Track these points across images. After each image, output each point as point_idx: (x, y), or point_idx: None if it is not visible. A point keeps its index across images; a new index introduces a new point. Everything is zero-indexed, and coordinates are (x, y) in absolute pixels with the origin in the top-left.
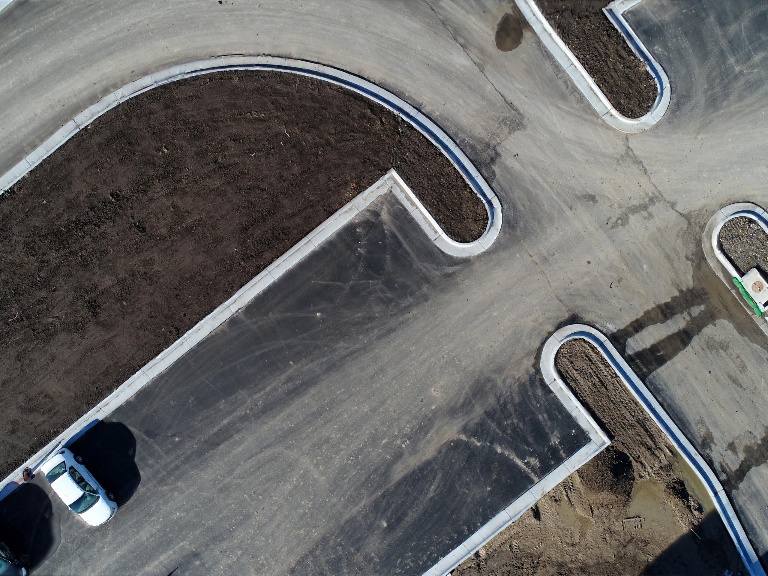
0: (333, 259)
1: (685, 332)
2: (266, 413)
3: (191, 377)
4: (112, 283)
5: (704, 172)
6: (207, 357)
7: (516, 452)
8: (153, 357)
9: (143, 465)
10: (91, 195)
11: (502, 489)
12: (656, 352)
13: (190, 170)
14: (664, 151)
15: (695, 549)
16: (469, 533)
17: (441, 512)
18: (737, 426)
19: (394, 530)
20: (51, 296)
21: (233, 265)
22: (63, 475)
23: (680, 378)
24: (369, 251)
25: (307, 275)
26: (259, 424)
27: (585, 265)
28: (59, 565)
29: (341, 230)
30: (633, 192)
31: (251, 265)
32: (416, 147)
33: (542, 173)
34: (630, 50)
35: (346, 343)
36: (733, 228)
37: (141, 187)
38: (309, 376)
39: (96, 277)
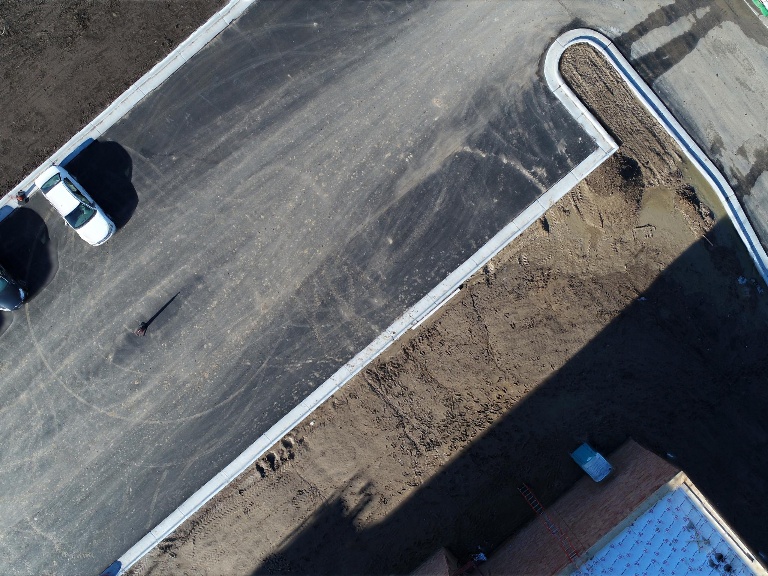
0: None
1: (691, 34)
2: (265, 129)
3: (186, 92)
4: None
5: None
6: (202, 71)
7: (522, 162)
8: (146, 71)
9: (140, 186)
10: None
11: (509, 200)
12: (662, 56)
13: None
14: None
15: (707, 257)
16: (477, 247)
17: (448, 226)
18: (747, 129)
19: (400, 247)
20: (39, 10)
21: None
22: (58, 185)
23: (687, 82)
24: None
25: None
26: (258, 141)
27: None
28: (58, 293)
29: None
30: None
31: None
32: None
33: None
34: None
35: (344, 54)
36: None
37: None
38: (308, 89)
39: None
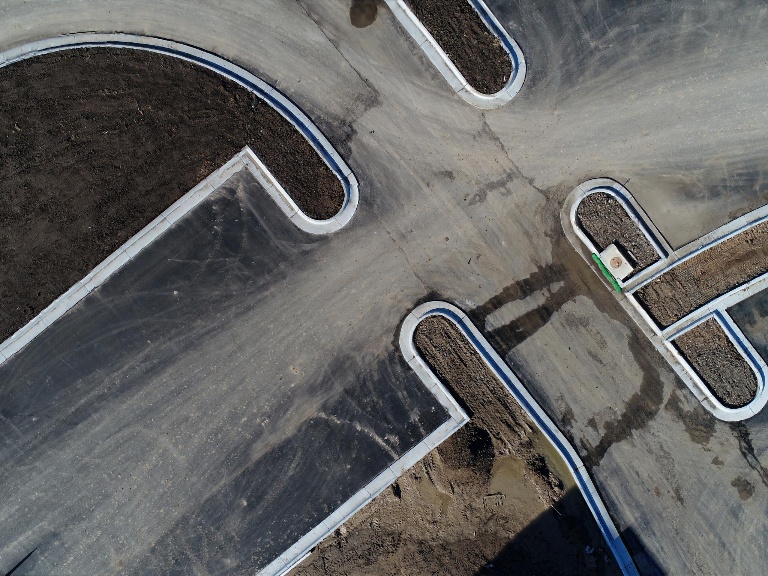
0: (189, 237)
1: (544, 308)
2: (124, 392)
3: (47, 356)
4: None
5: (561, 148)
6: (63, 336)
7: (376, 429)
8: (8, 336)
9: (0, 445)
10: None
11: (362, 467)
12: (515, 328)
13: (43, 148)
14: (521, 127)
15: (556, 525)
16: (329, 511)
17: (301, 490)
18: (597, 402)
19: (254, 509)
20: None
21: (88, 243)
22: None
23: (540, 354)
24: (225, 229)
25: (163, 253)
26: (117, 403)
27: (443, 242)
28: None
29: (197, 208)
30: (490, 168)
31: (106, 243)
32: (270, 124)
33: (399, 150)
34: (484, 26)
35: (204, 321)
36: (591, 204)
37: None
38: (167, 355)
39: None
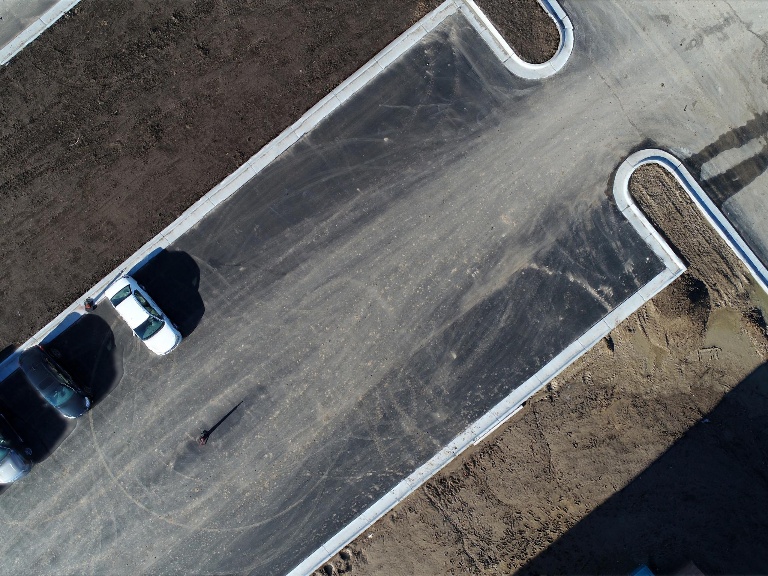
0: (401, 82)
1: (761, 157)
2: (332, 242)
3: (256, 204)
4: (175, 106)
5: None
6: (272, 183)
7: (589, 281)
8: (217, 183)
9: (207, 295)
10: (153, 16)
11: (575, 319)
12: (732, 177)
13: None
14: None
15: None
16: (541, 364)
17: (512, 343)
18: None
19: (464, 362)
20: (113, 120)
21: (299, 87)
22: (128, 298)
23: (757, 204)
24: (437, 74)
25: (374, 98)
26: (325, 253)
27: (658, 88)
28: (121, 399)
29: (409, 52)
30: (707, 12)
31: (317, 87)
32: None
33: None
34: None
35: (414, 169)
36: None
37: (204, 7)
38: (376, 203)
39: (159, 100)
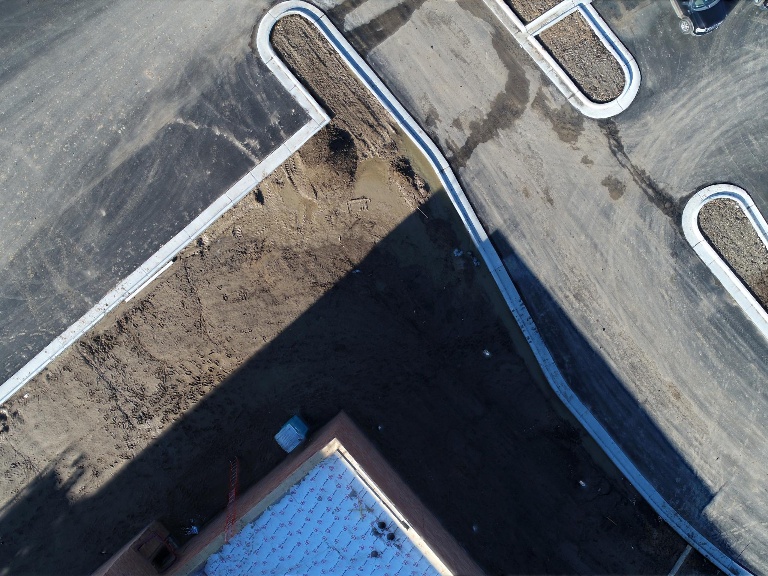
0: None
1: (405, 6)
2: None
3: None
4: None
5: None
6: None
7: (235, 134)
8: None
9: None
10: None
11: (222, 172)
12: (376, 27)
13: None
14: None
15: (423, 229)
16: (190, 219)
17: (161, 198)
18: (462, 102)
19: (113, 219)
20: None
21: None
22: None
23: (402, 54)
24: None
25: None
26: None
27: None
28: None
29: None
30: None
31: None
32: None
33: None
34: None
35: (55, 25)
36: None
37: None
38: (18, 61)
39: None
